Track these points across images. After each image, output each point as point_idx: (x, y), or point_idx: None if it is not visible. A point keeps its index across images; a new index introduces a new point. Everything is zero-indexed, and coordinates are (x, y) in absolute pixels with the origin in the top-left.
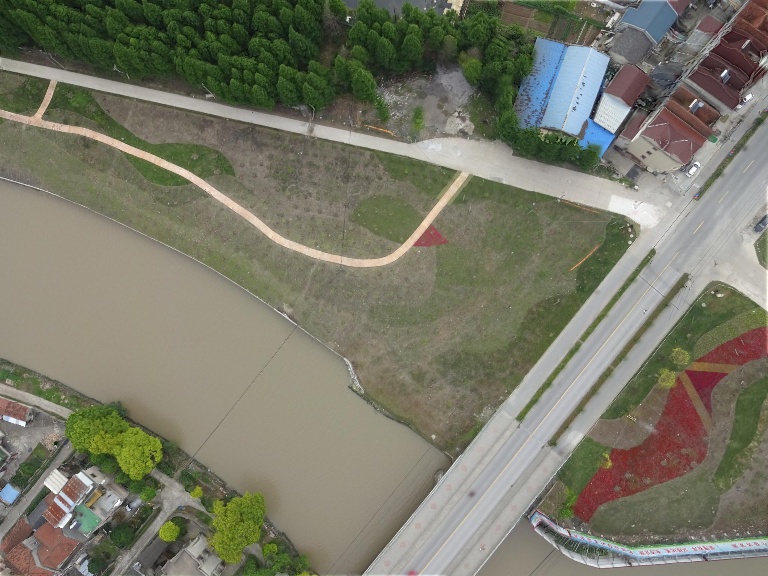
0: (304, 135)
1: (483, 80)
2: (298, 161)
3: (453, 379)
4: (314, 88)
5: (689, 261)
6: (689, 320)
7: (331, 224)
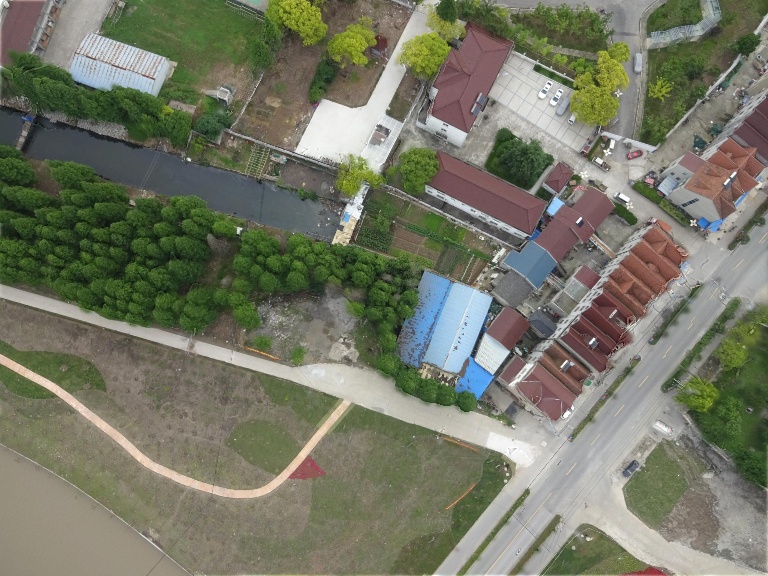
0: (184, 351)
1: (368, 313)
2: (175, 378)
3: None
4: (191, 319)
5: (561, 502)
6: (559, 563)
7: (205, 448)
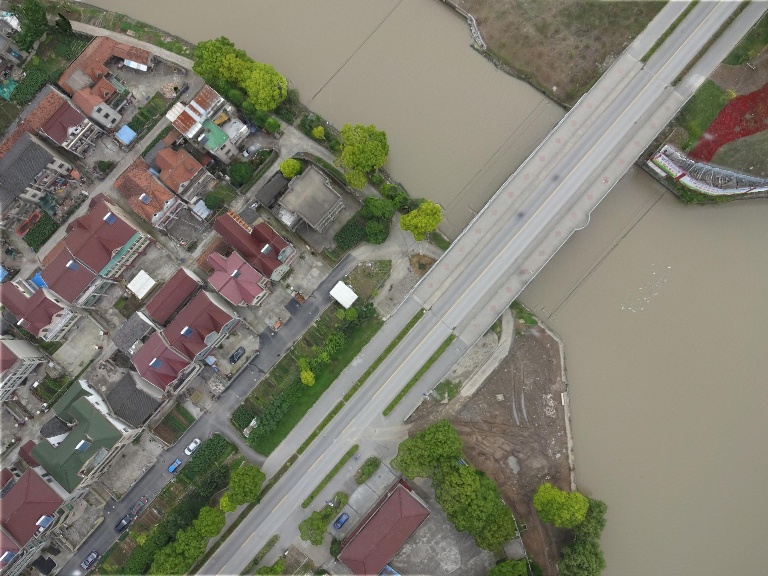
0: None
1: None
2: None
3: (577, 29)
4: None
5: None
6: None
7: None
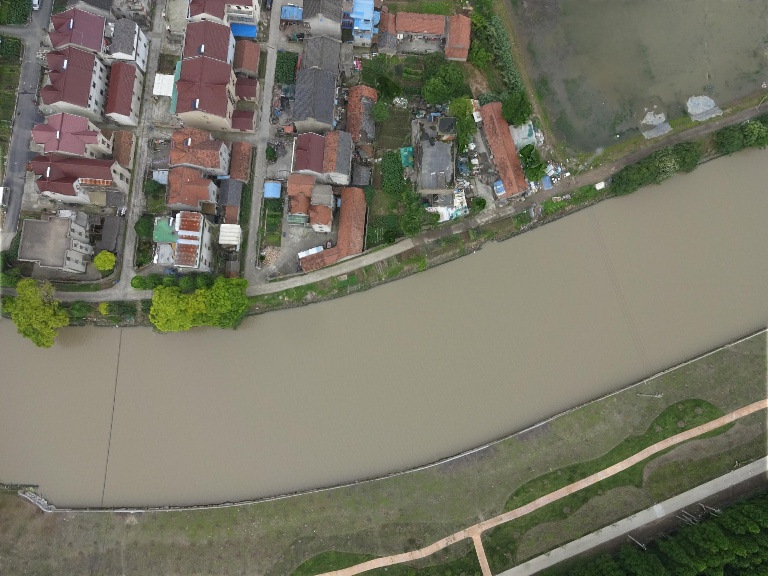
0: None
1: None
2: None
3: None
4: None
5: None
6: None
7: None
